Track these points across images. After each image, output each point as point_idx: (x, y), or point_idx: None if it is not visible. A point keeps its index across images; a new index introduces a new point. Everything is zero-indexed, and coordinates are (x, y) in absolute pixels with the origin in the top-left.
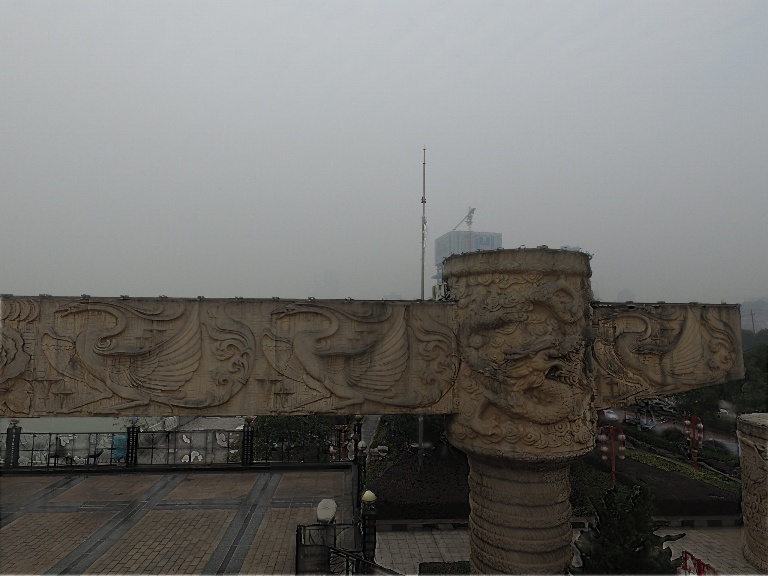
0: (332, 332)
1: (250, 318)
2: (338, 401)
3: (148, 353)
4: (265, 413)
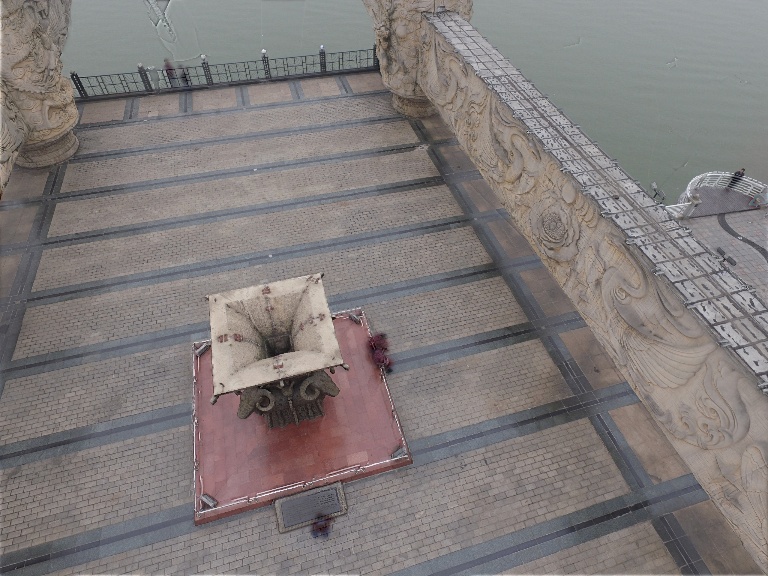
0: None
1: (760, 416)
2: None
3: None
4: (701, 484)
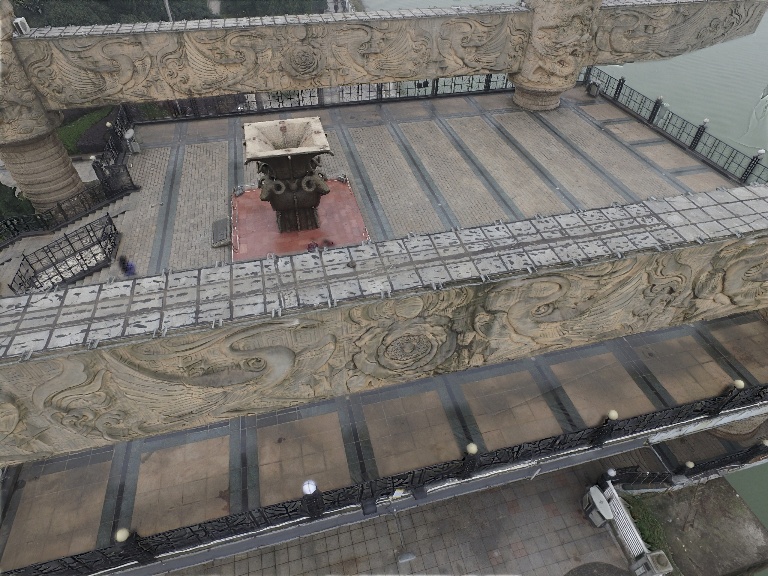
0: None
1: None
2: None
3: None
4: None
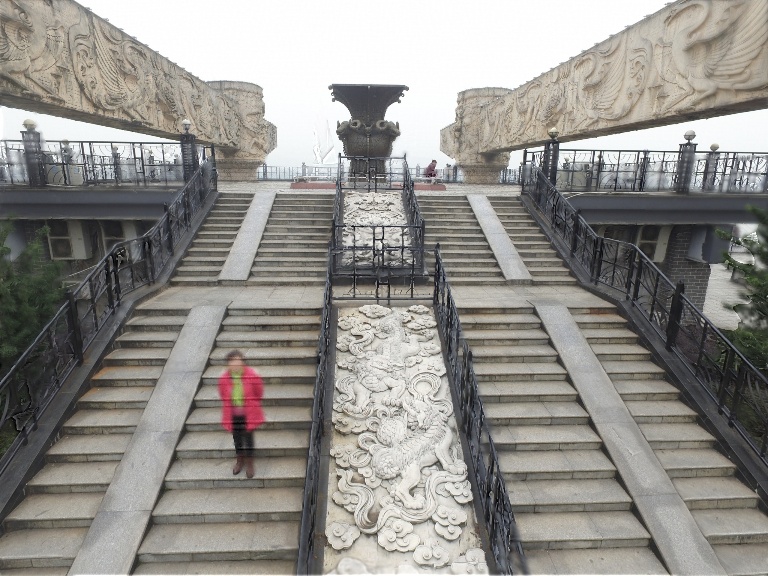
0: (702, 21)
1: (652, 32)
2: (698, 96)
3: (600, 83)
4: (649, 118)
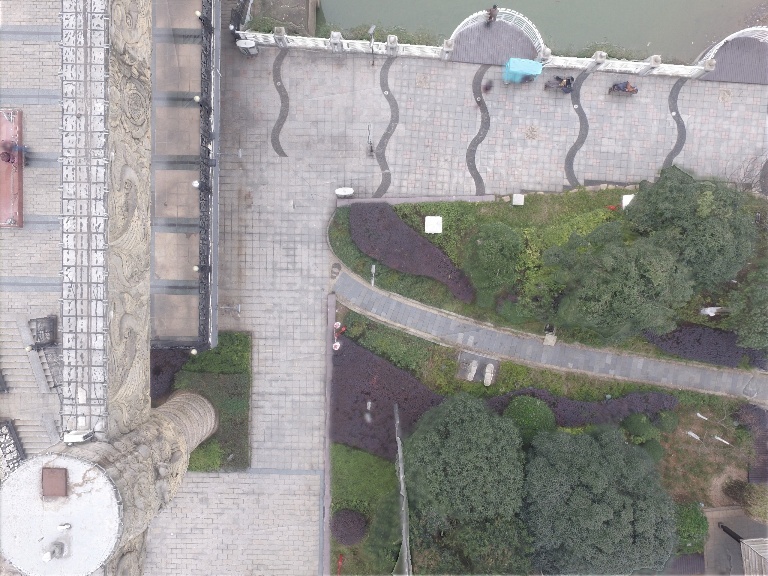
0: None
1: None
2: None
3: None
4: None
